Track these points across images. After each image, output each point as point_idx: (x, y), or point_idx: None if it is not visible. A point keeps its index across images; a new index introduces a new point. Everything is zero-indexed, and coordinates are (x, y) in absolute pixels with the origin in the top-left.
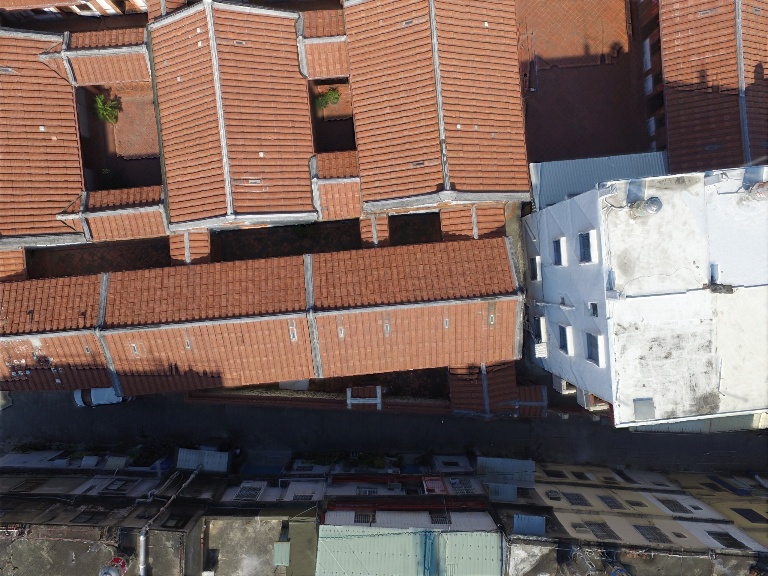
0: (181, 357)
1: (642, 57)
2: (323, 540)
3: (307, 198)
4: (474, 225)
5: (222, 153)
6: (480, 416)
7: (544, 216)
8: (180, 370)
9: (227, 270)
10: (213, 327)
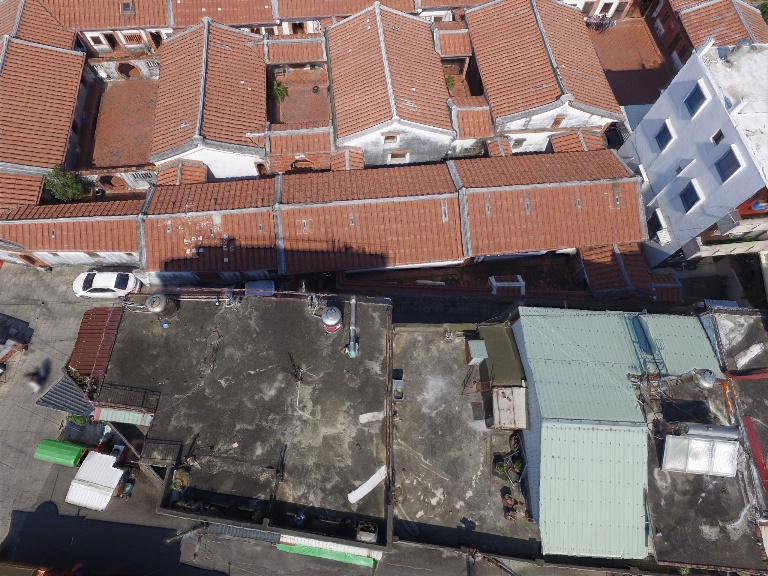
0: (344, 234)
1: (673, 64)
2: (525, 317)
3: (448, 122)
4: (583, 142)
5: (387, 83)
6: (623, 291)
7: (640, 129)
8: (342, 247)
9: (383, 173)
10: (376, 205)
